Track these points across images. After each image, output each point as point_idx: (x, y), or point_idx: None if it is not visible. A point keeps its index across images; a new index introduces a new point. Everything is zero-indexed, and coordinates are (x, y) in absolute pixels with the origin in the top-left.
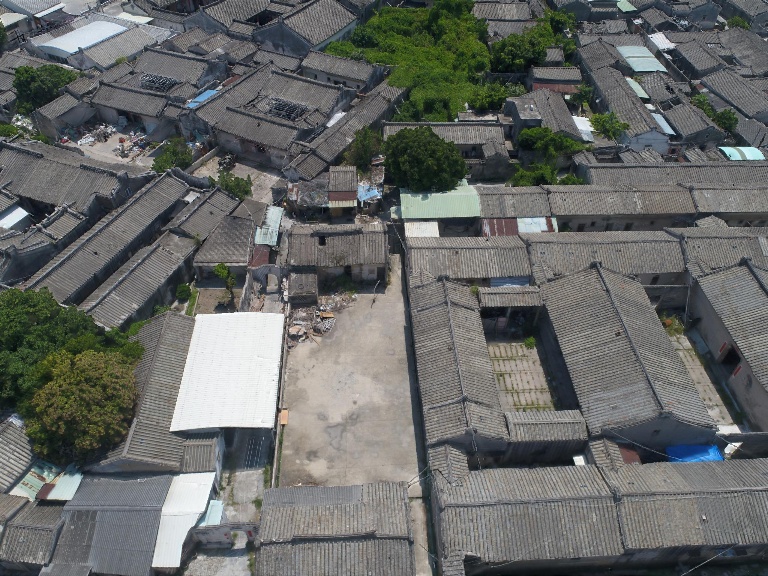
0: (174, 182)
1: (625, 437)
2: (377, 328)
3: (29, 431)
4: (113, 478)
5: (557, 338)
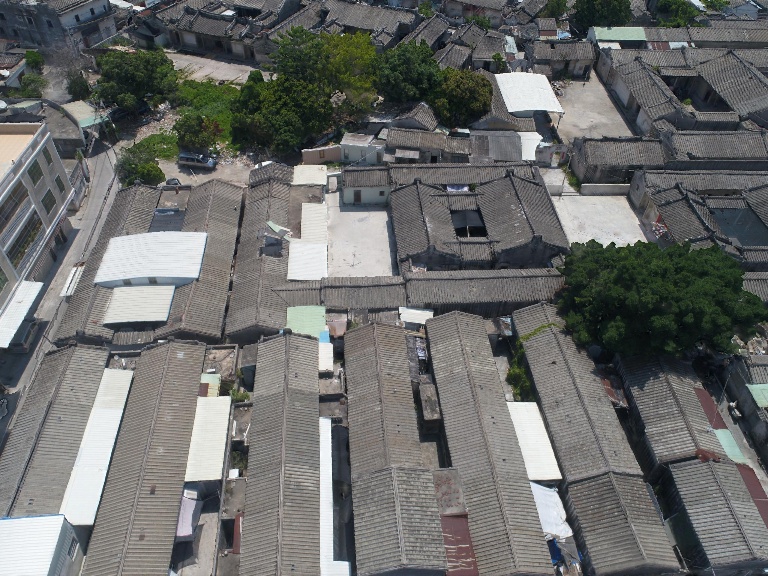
0: (440, 21)
1: (761, 118)
2: (591, 95)
3: (444, 101)
4: (484, 130)
5: (712, 86)
